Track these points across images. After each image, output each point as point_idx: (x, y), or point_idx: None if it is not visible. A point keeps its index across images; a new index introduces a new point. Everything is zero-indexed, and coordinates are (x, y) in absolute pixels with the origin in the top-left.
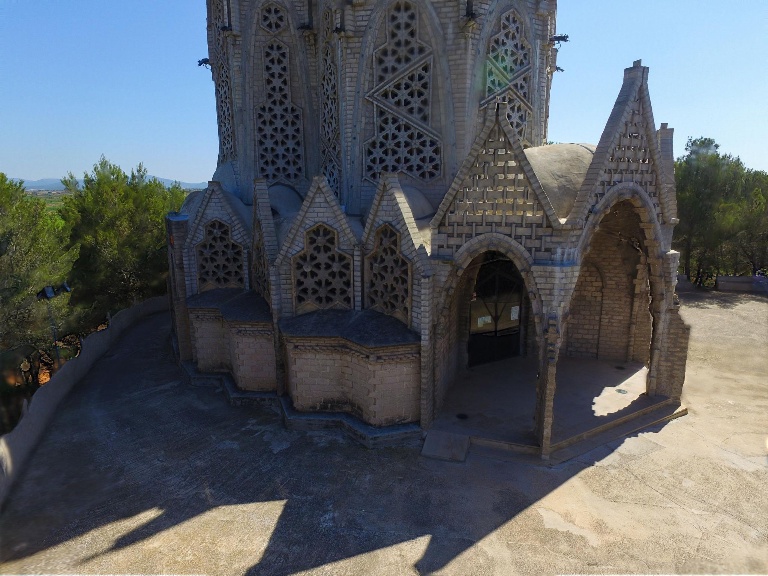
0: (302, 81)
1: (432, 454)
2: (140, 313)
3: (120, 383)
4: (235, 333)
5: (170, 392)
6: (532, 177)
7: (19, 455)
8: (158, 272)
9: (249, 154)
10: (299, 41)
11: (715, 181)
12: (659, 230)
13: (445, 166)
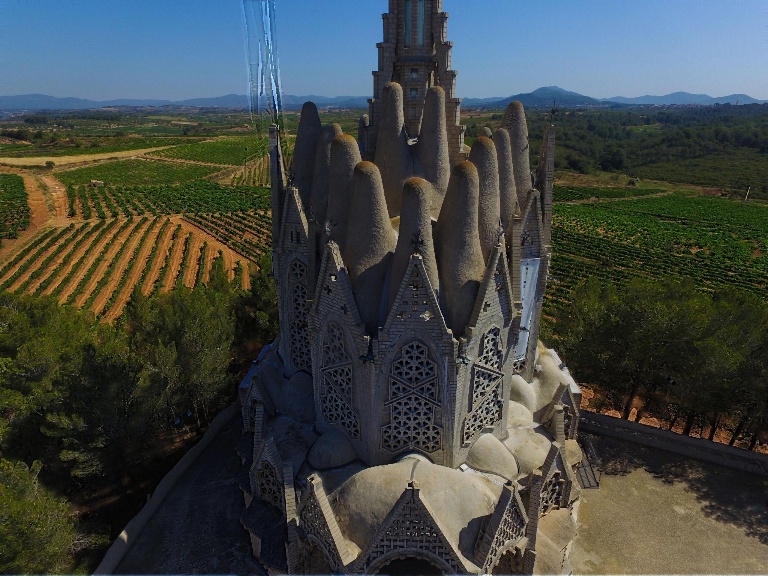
0: None
1: None
2: None
3: (213, 466)
4: (241, 488)
5: (225, 490)
6: (328, 531)
7: (140, 525)
8: None
9: (287, 348)
10: None
11: None
12: (456, 575)
13: (362, 434)
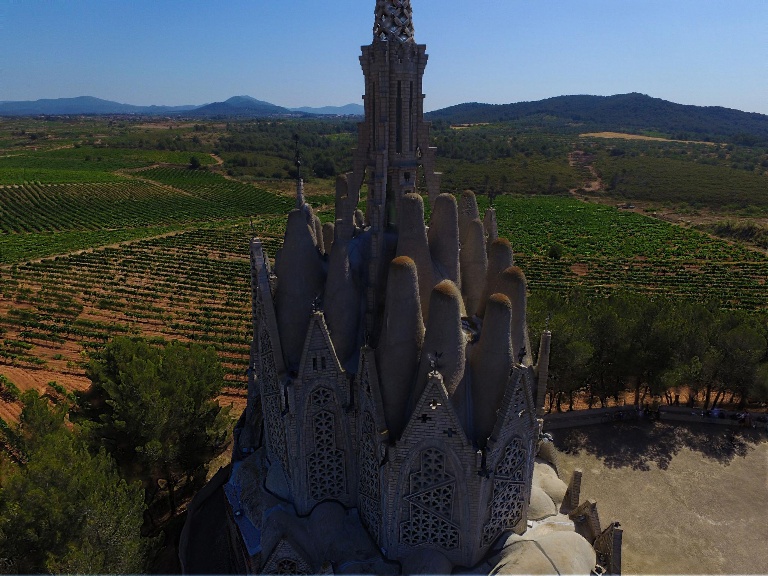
0: (344, 433)
1: None
2: (191, 513)
3: None
4: None
5: None
6: None
7: None
8: (195, 452)
9: (302, 484)
10: (342, 408)
11: (664, 342)
12: None
13: (461, 542)
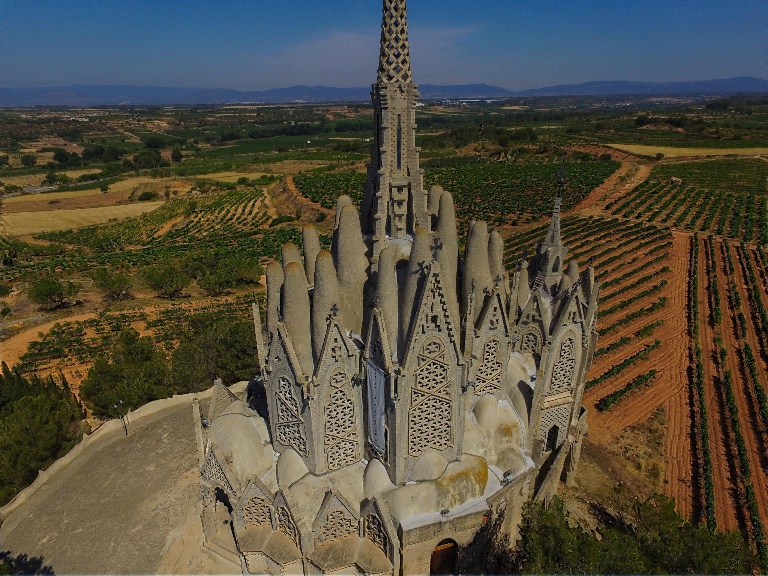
0: None
1: None
2: None
3: None
4: None
5: None
6: None
7: None
8: None
9: None
10: None
11: None
12: None
13: None
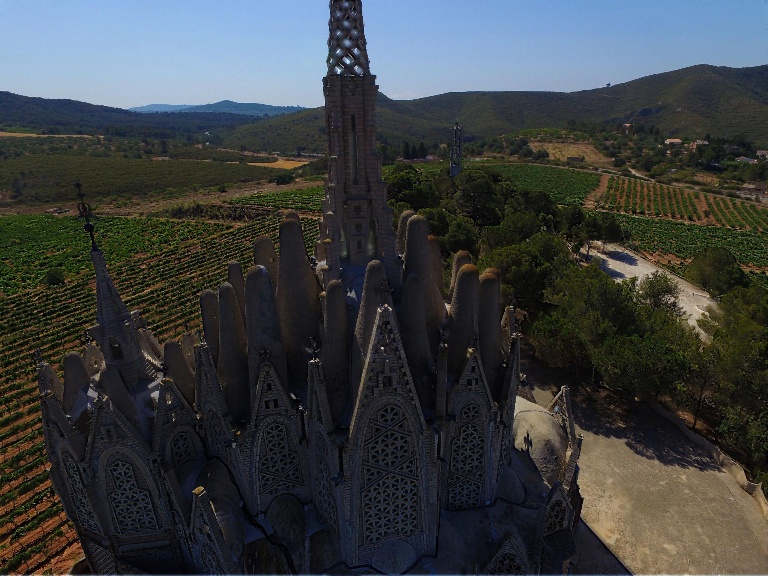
0: None
1: (577, 562)
2: None
3: None
4: None
5: None
6: None
7: None
8: None
9: None
10: None
11: None
12: None
13: None
